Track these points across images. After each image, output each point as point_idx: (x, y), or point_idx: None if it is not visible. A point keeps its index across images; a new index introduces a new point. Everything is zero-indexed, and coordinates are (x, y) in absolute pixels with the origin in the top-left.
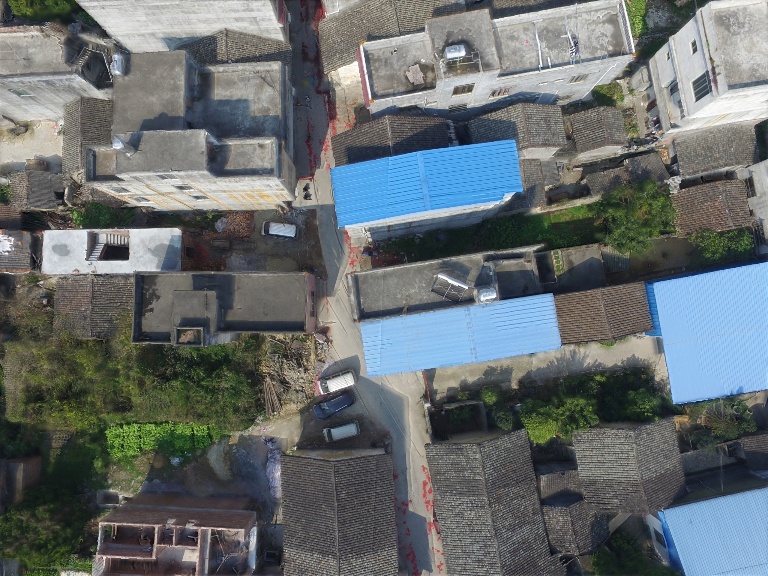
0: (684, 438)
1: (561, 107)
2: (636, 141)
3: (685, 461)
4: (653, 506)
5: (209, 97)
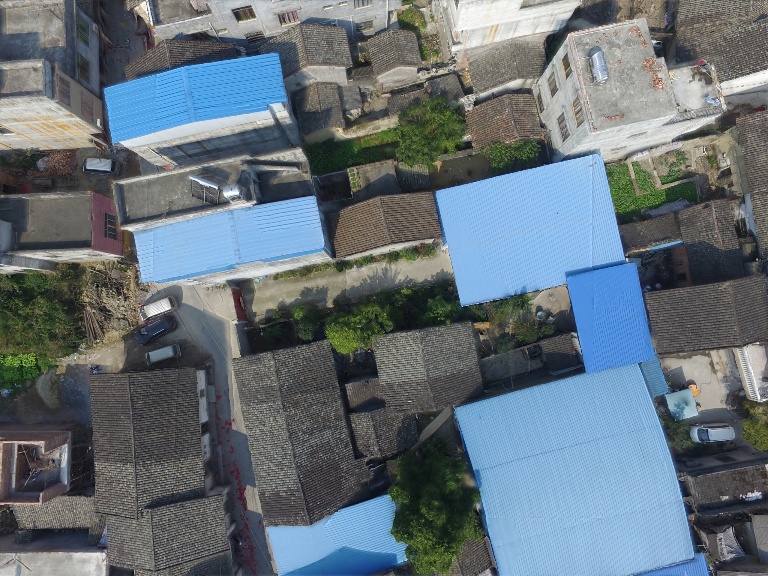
0: (490, 345)
1: (369, 37)
2: (440, 66)
3: (495, 369)
4: (441, 403)
5: (1, 32)
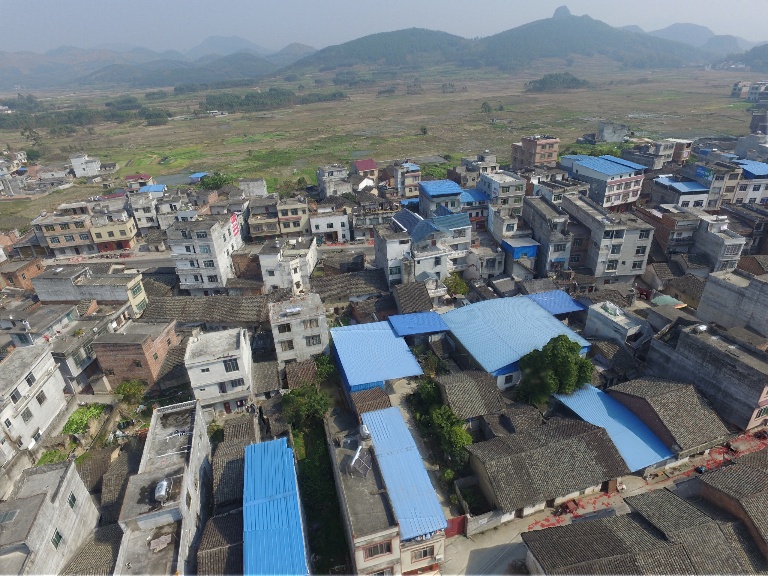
0: None
1: None
2: None
3: None
4: None
5: None
